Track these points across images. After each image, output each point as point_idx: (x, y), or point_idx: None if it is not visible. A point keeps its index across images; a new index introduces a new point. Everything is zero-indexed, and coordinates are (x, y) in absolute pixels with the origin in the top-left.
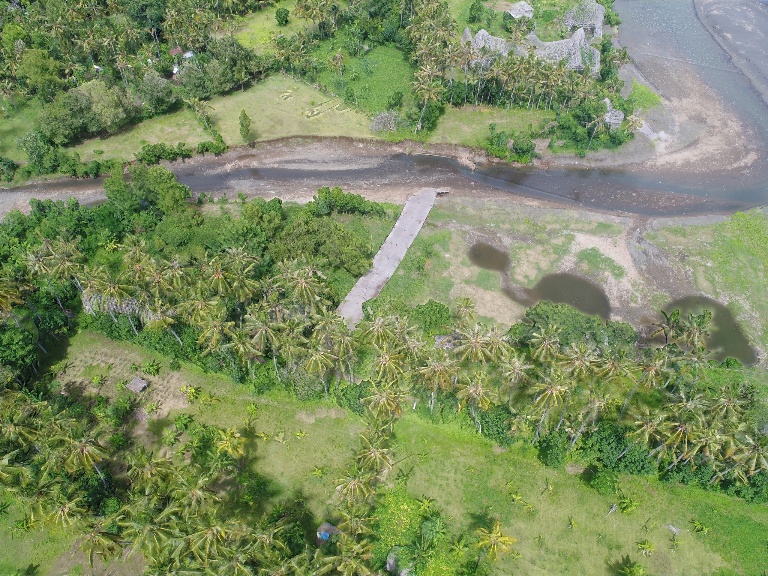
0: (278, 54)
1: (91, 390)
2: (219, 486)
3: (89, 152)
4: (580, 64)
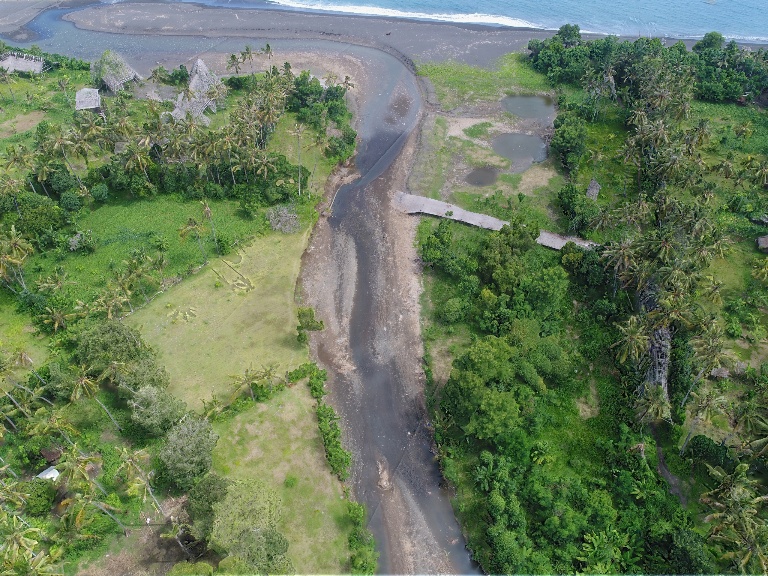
0: (98, 307)
1: None
2: (766, 306)
3: (311, 570)
4: (224, 85)
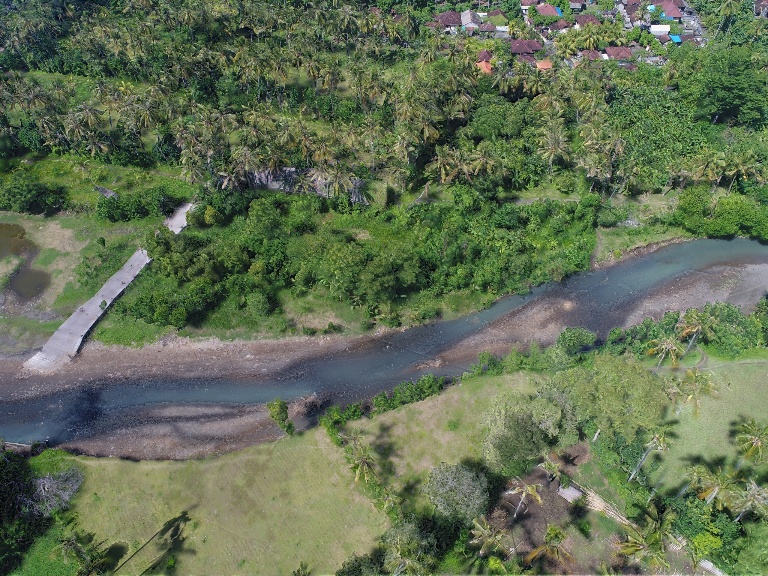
0: None
1: (366, 165)
2: None
3: None
4: None
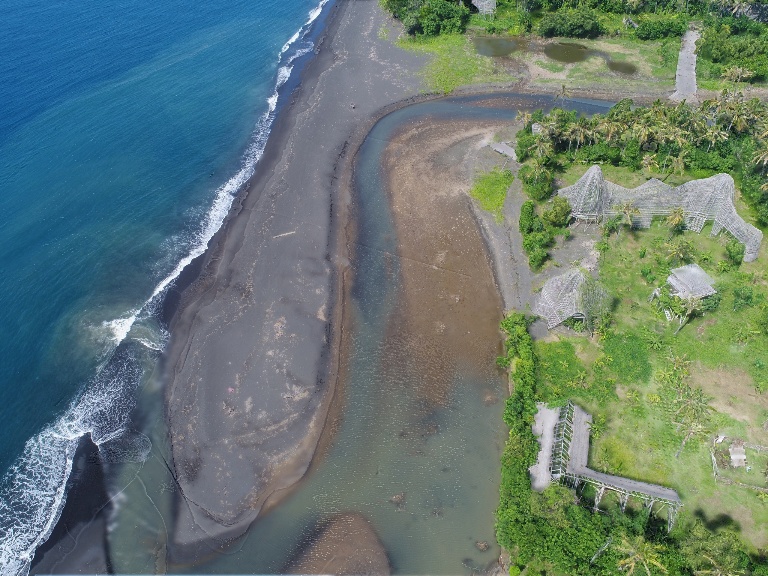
0: None
1: None
2: None
3: None
4: None
